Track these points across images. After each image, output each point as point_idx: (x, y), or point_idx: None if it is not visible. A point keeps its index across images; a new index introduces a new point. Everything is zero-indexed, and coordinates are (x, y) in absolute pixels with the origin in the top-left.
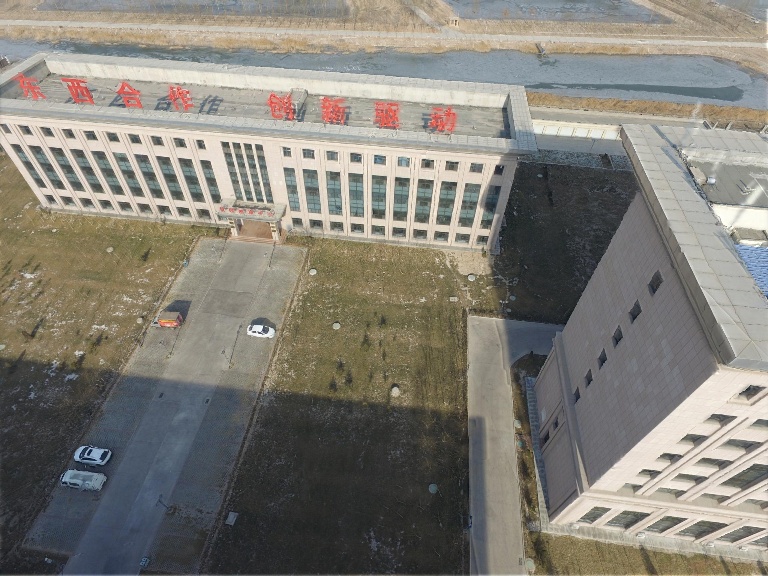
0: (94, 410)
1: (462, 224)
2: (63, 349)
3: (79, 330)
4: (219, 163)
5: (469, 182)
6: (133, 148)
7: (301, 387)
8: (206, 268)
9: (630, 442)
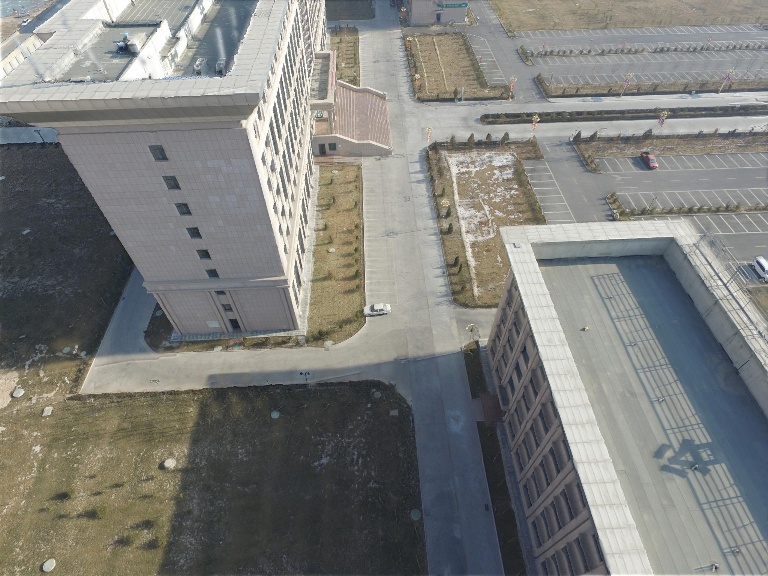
0: None
1: None
2: None
3: None
4: None
5: None
6: None
7: None
8: None
9: (266, 223)
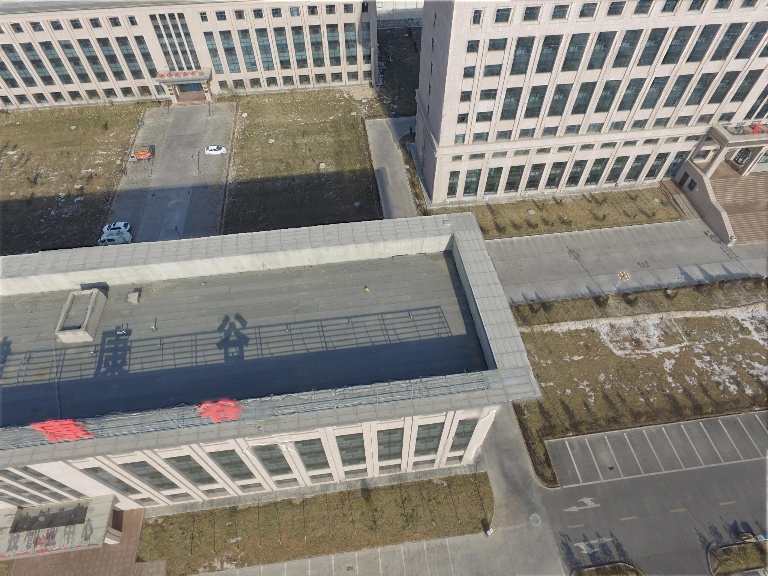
0: (106, 211)
1: (350, 63)
2: (64, 186)
3: (71, 175)
4: (150, 36)
5: (346, 22)
6: (75, 33)
7: (255, 175)
8: (159, 125)
9: None
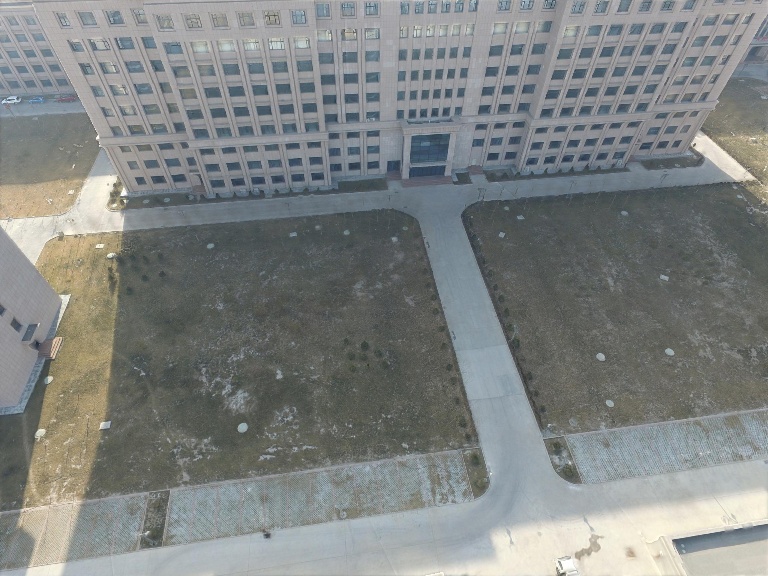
0: None
1: None
2: None
3: None
4: None
5: None
6: None
7: None
8: None
9: None
